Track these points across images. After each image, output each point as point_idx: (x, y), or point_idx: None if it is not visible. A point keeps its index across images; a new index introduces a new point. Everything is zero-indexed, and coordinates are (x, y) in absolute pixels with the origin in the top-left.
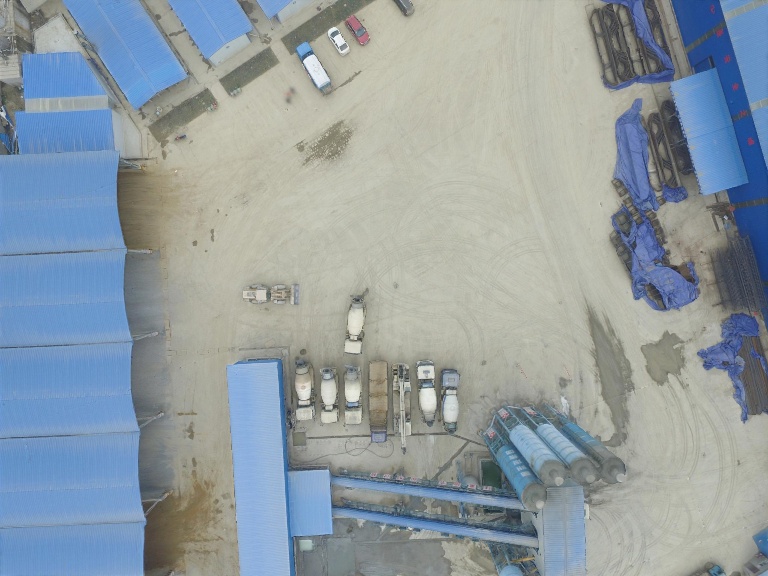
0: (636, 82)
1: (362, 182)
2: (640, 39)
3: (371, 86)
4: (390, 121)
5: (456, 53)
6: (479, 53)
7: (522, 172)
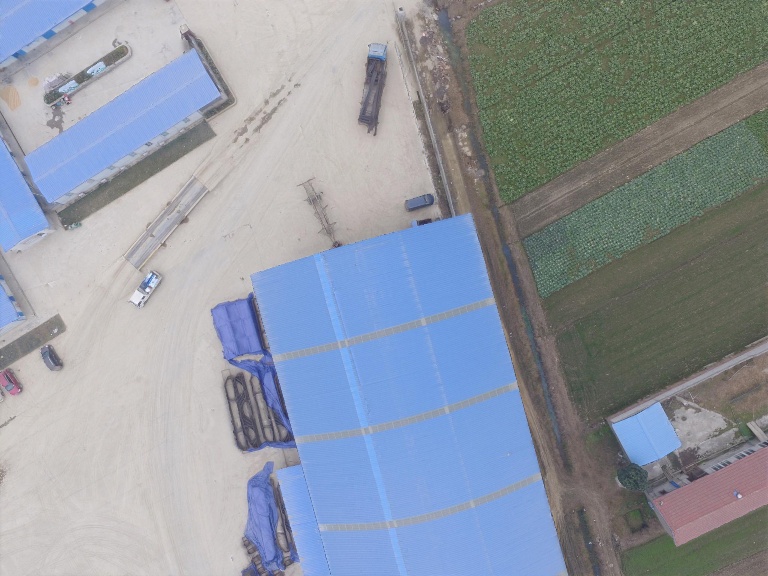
0: (268, 446)
1: (13, 518)
2: (270, 407)
3: (24, 431)
4: (40, 464)
5: (101, 406)
6: (122, 408)
7: (159, 522)
